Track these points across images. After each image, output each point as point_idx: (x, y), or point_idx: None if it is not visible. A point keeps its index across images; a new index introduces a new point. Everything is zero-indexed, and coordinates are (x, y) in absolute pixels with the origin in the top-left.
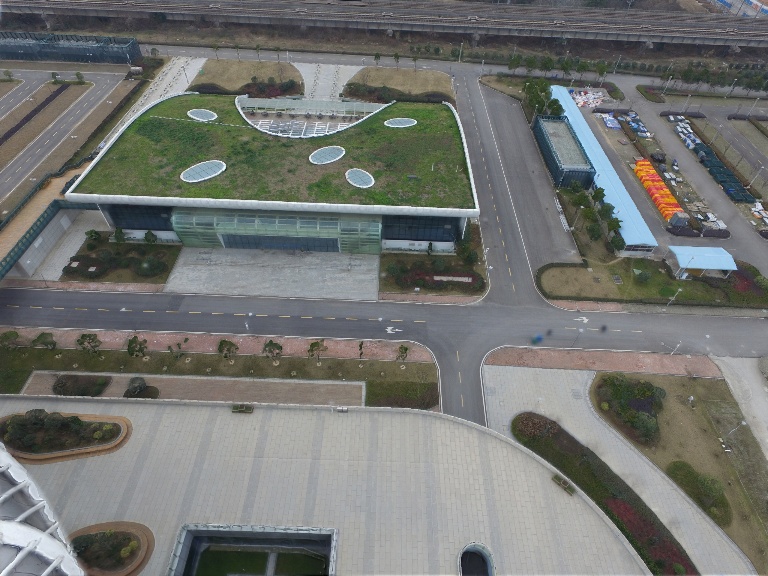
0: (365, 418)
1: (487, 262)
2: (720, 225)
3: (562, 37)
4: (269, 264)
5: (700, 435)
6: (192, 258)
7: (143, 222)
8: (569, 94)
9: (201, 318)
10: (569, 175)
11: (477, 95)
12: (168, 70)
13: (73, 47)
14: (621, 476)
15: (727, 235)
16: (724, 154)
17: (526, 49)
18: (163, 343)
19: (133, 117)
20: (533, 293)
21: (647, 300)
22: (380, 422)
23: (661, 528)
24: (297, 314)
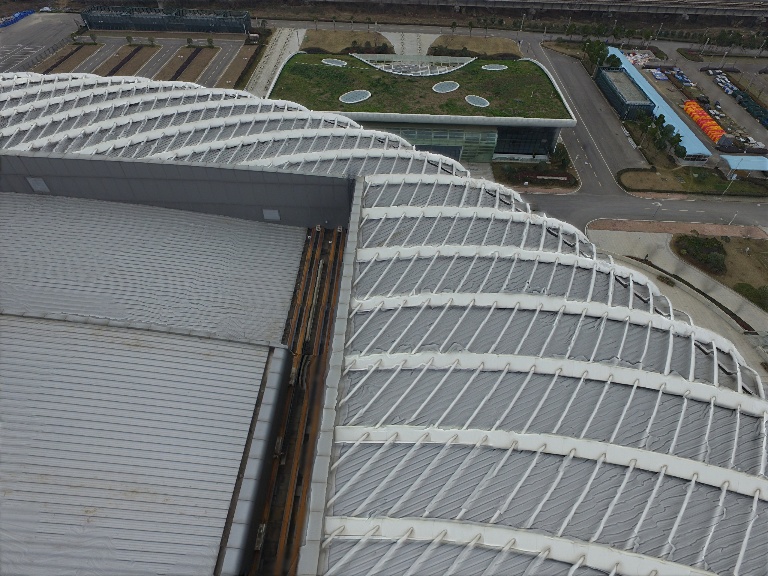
0: None
1: (576, 168)
2: (759, 145)
3: (608, 11)
4: None
5: (756, 270)
6: None
7: None
8: None
9: None
10: (633, 109)
11: (542, 56)
12: (277, 38)
13: (198, 19)
14: (701, 290)
15: (766, 152)
16: (758, 97)
17: (576, 22)
18: None
19: (284, 62)
20: (616, 187)
21: (706, 191)
22: None
23: None
24: None
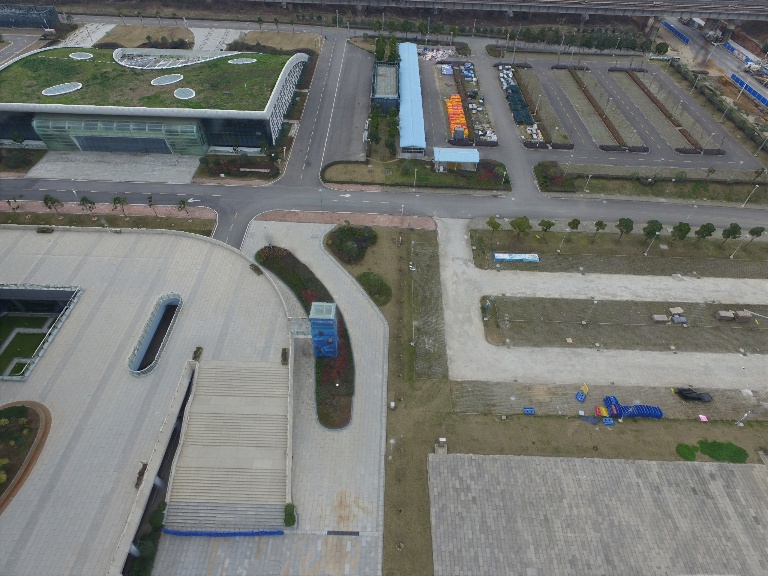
0: (133, 236)
1: (289, 160)
2: (492, 138)
3: (434, 7)
4: (113, 161)
5: (395, 259)
6: (54, 157)
7: (19, 132)
8: (416, 49)
9: (47, 193)
10: (379, 102)
11: (340, 51)
12: (79, 33)
13: None
14: (321, 280)
15: (494, 144)
16: (526, 91)
17: (404, 18)
18: (12, 207)
19: (21, 56)
20: (315, 179)
21: (402, 183)
22: (142, 238)
23: None
24: (123, 191)
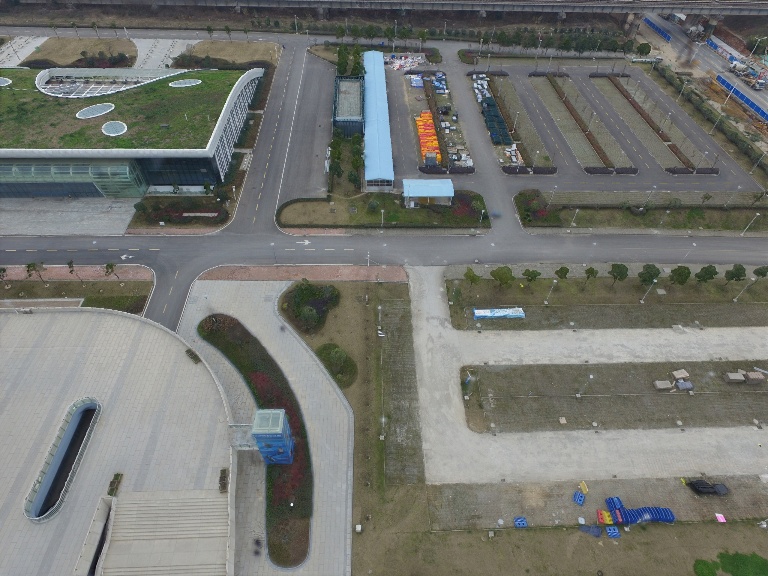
0: (46, 317)
1: (240, 200)
2: (467, 163)
3: (401, 8)
4: (35, 209)
5: (361, 324)
6: None
7: None
8: (383, 58)
9: None
10: (342, 125)
11: (299, 62)
12: (6, 49)
13: None
14: (274, 356)
15: (470, 171)
16: (503, 105)
17: (369, 21)
18: None
19: None
20: (270, 223)
21: (368, 224)
22: (57, 319)
23: (284, 390)
24: (44, 248)
